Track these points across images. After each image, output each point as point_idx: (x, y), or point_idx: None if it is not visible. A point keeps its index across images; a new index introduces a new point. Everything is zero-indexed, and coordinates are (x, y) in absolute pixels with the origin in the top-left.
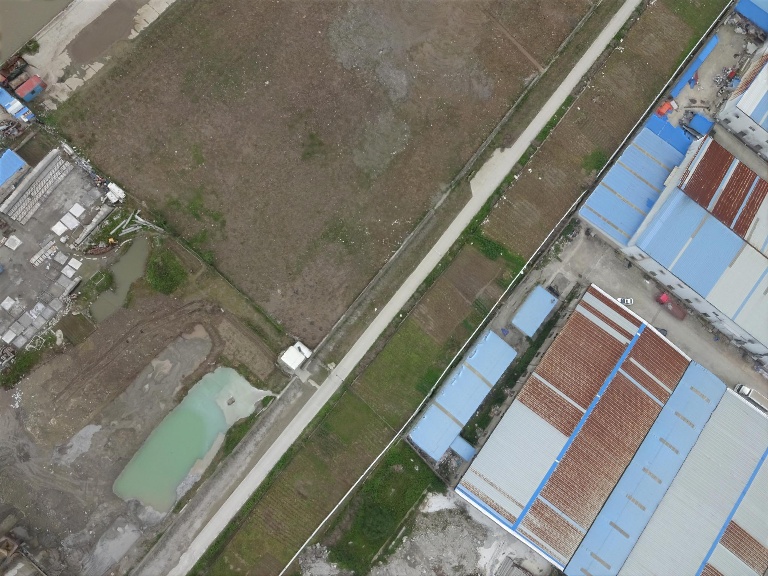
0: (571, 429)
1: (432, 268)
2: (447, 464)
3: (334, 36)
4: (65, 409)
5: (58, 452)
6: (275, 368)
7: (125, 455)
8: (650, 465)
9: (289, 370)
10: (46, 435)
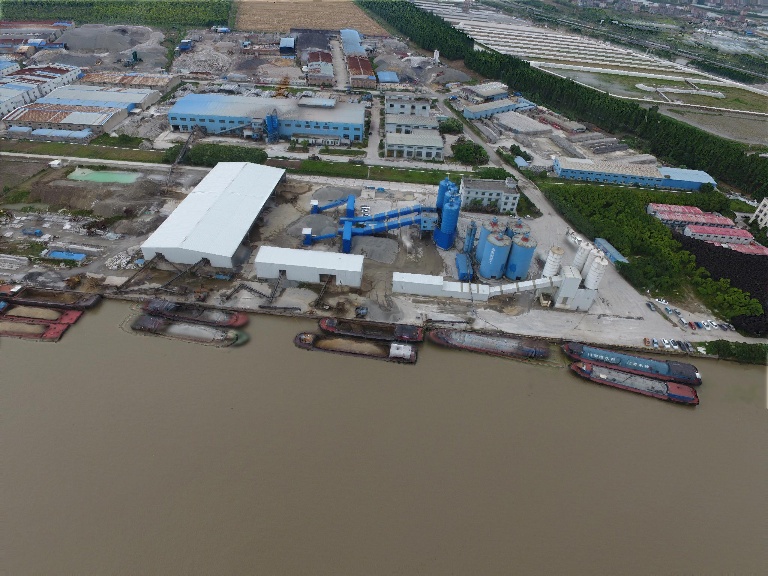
0: (69, 112)
1: (3, 152)
2: None
3: None
4: None
5: None
6: None
7: None
8: (80, 102)
9: None
10: None
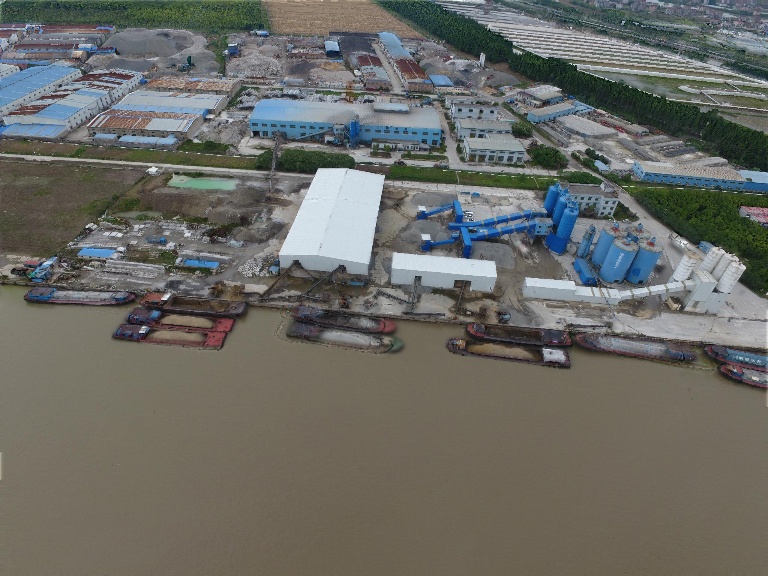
0: None
1: None
2: None
3: None
4: None
5: None
6: None
7: None
8: (155, 108)
9: None
10: None
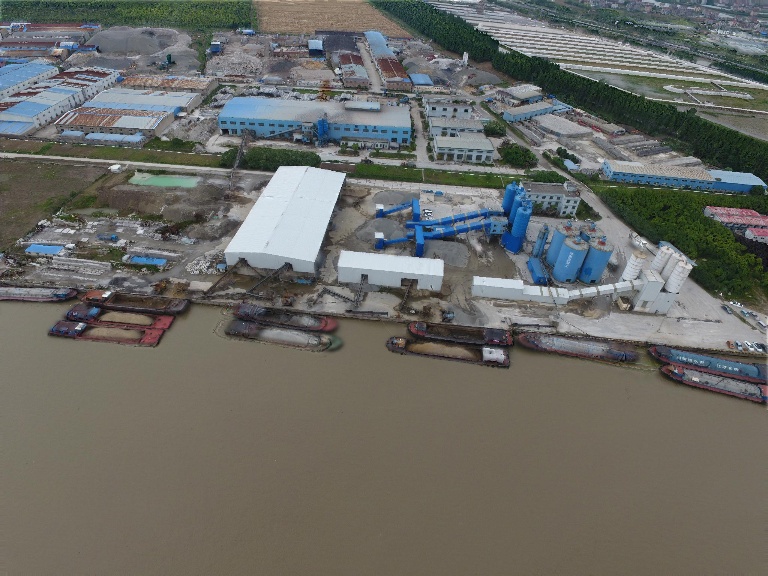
0: (119, 116)
1: None
2: None
3: None
4: None
5: None
6: (123, 172)
7: None
8: (127, 106)
9: None
10: None
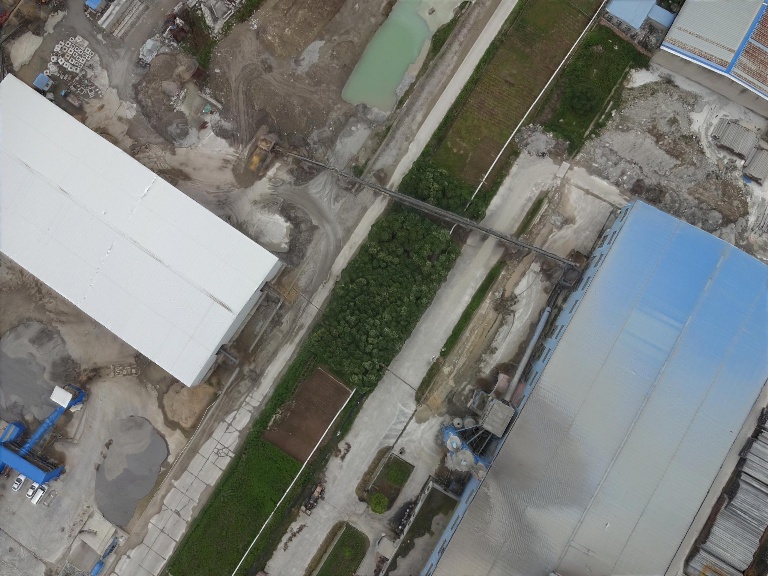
0: None
1: None
2: (646, 42)
3: None
4: (295, 21)
5: (294, 63)
6: None
7: (348, 63)
8: None
9: None
10: (284, 44)
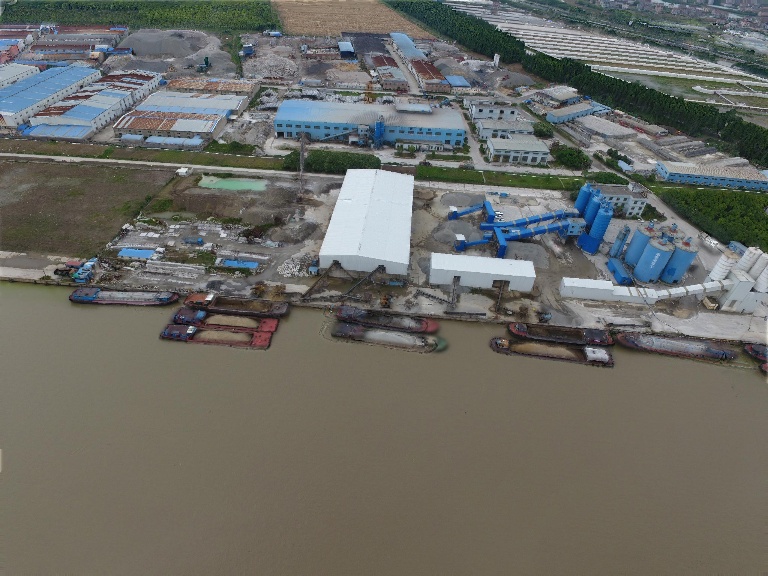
0: None
1: None
2: None
3: (2, 205)
4: None
5: None
6: None
7: None
8: (179, 109)
9: (190, 173)
10: None
